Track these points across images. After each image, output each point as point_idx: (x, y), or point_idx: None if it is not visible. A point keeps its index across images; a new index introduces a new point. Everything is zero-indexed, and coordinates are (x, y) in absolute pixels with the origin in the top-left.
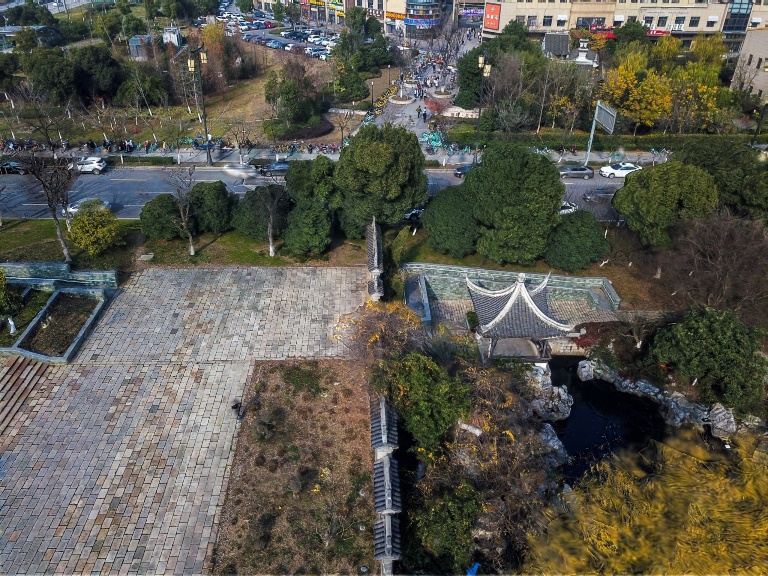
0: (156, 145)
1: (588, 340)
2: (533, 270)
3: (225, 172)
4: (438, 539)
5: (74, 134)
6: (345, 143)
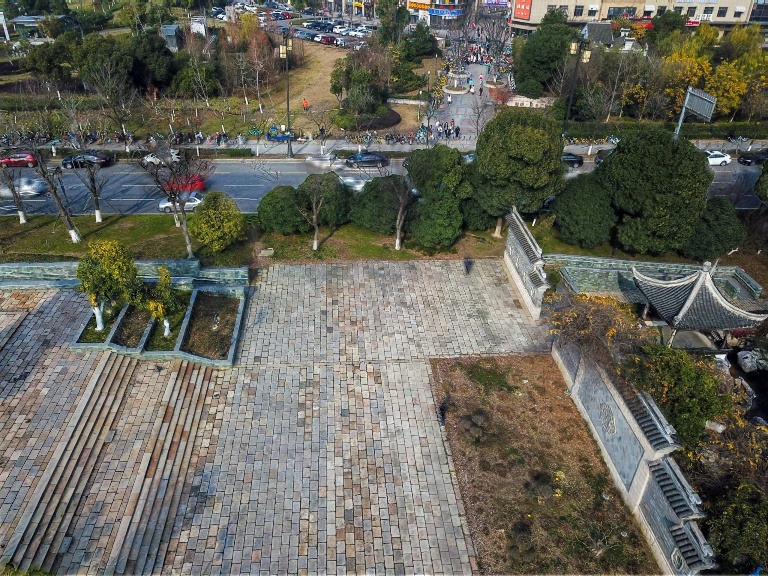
0: (226, 137)
1: (744, 330)
2: (663, 260)
3: (309, 164)
4: (736, 544)
5: (150, 125)
6: None
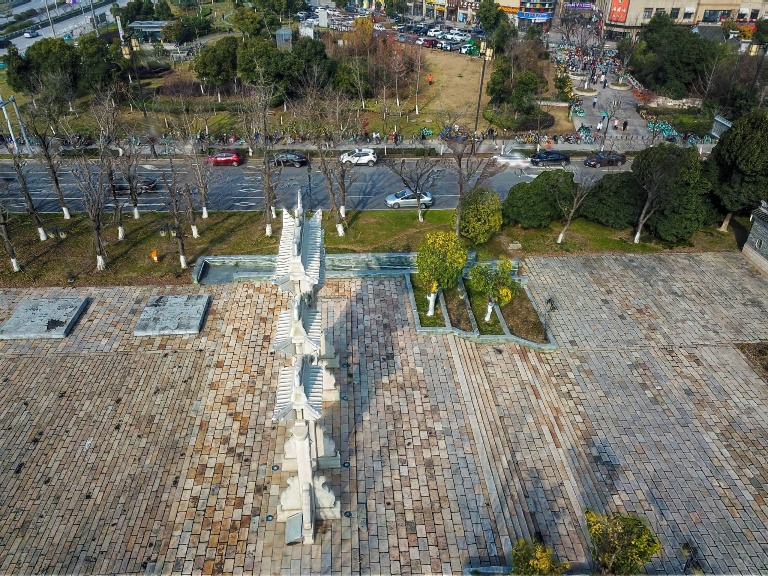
0: (401, 137)
1: None
2: None
3: None
4: None
5: None
6: None
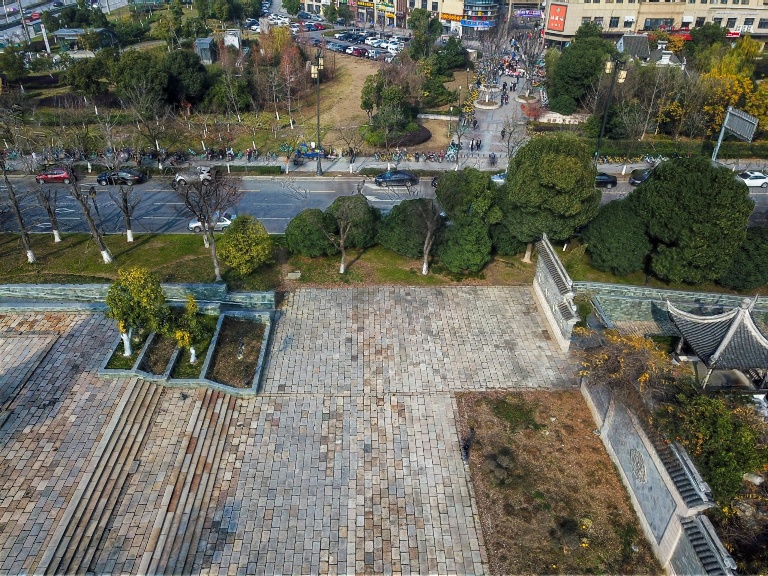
0: (257, 153)
1: None
2: (699, 289)
3: (338, 182)
4: None
5: (183, 143)
6: (450, 151)
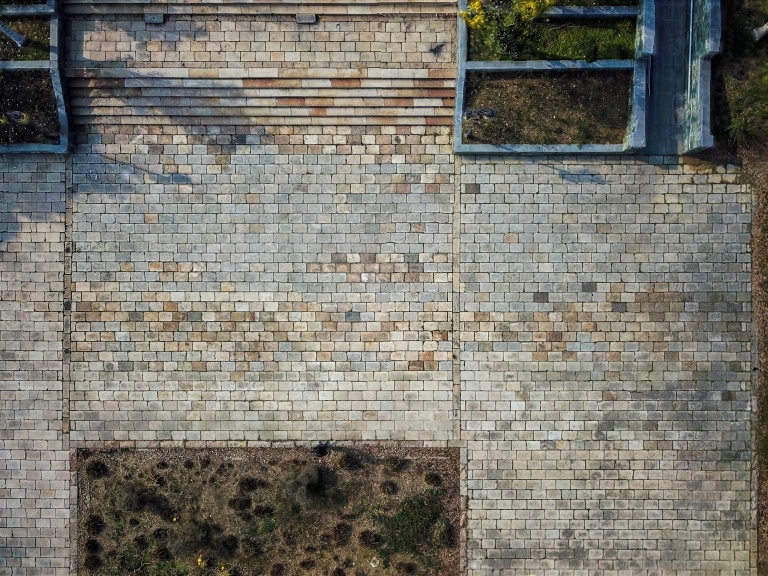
0: None
1: None
2: None
3: None
4: None
5: None
6: None
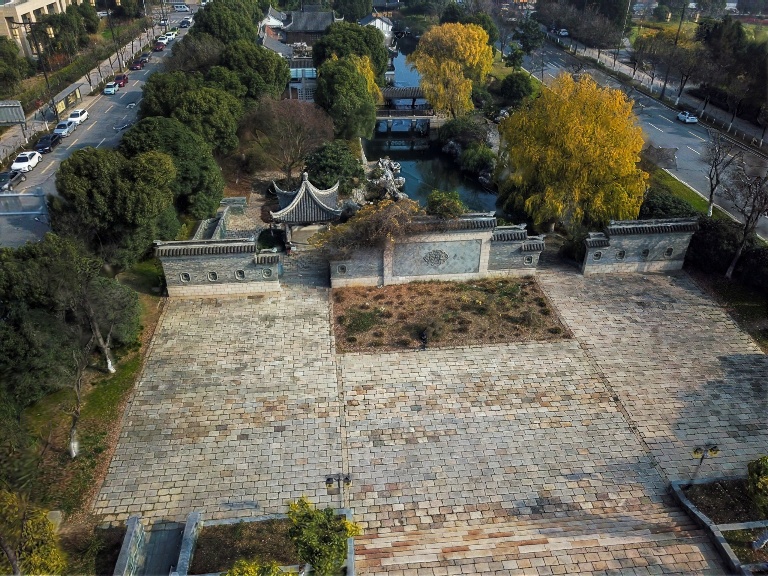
0: None
1: None
2: (192, 223)
3: None
4: None
5: None
6: None
